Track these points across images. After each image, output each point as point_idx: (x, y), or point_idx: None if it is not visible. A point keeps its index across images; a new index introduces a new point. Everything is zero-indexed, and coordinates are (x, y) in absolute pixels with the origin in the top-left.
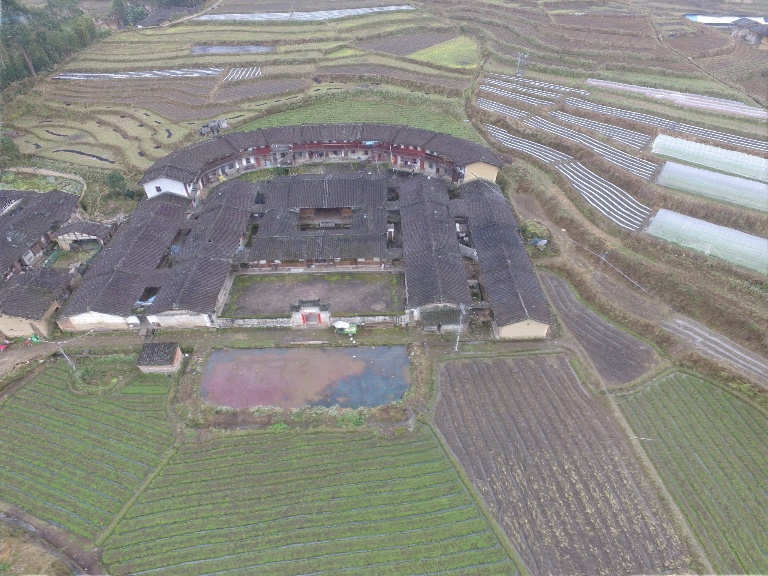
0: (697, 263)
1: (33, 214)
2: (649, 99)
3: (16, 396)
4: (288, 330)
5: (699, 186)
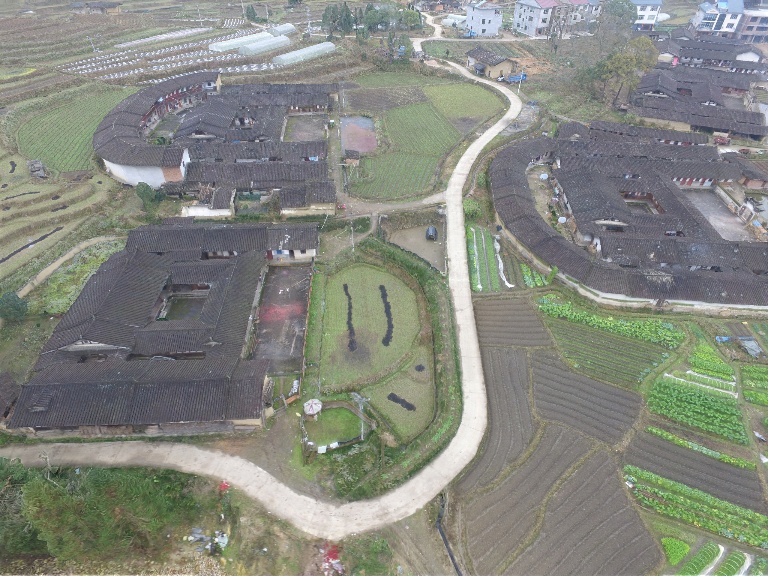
0: (308, 62)
1: (181, 228)
2: (163, 41)
3: (377, 196)
4: (330, 137)
5: (263, 48)
